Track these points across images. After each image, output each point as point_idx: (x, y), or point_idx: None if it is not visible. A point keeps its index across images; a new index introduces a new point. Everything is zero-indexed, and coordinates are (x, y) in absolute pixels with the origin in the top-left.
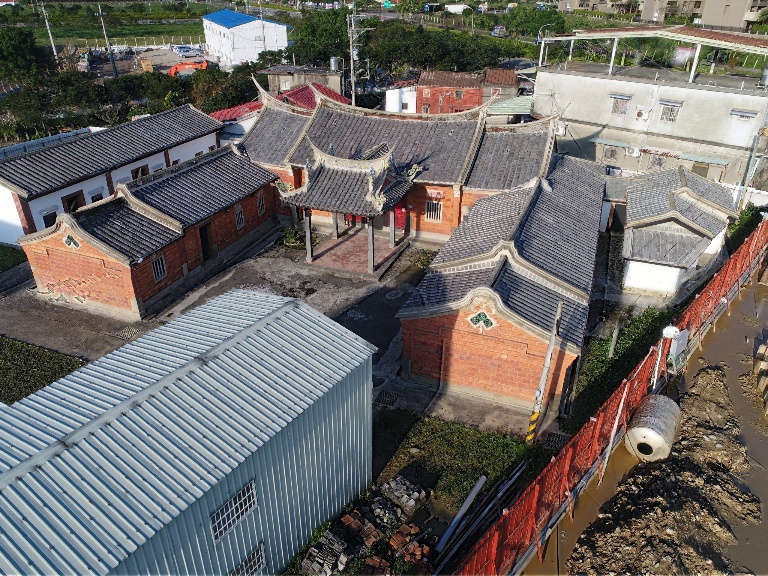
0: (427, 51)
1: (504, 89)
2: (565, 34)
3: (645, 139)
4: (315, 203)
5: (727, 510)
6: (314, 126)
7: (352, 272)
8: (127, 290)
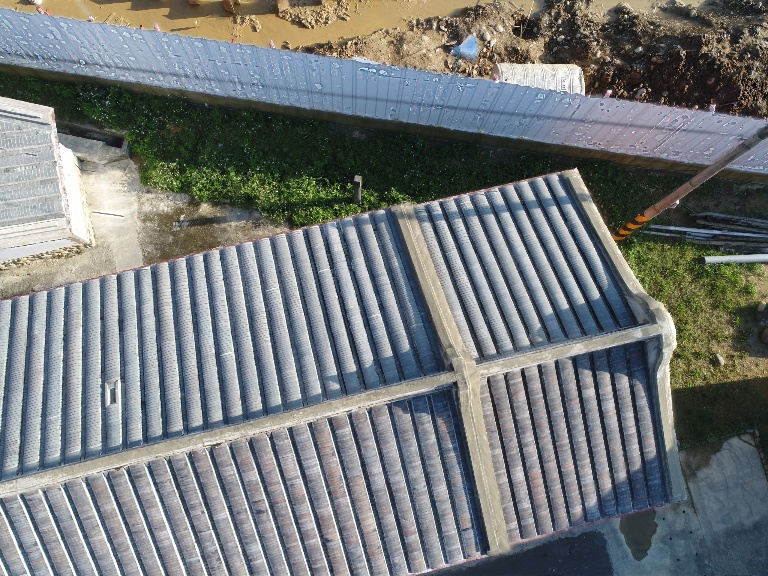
0: None
1: None
2: None
3: None
4: None
5: (591, 14)
6: None
7: None
8: None
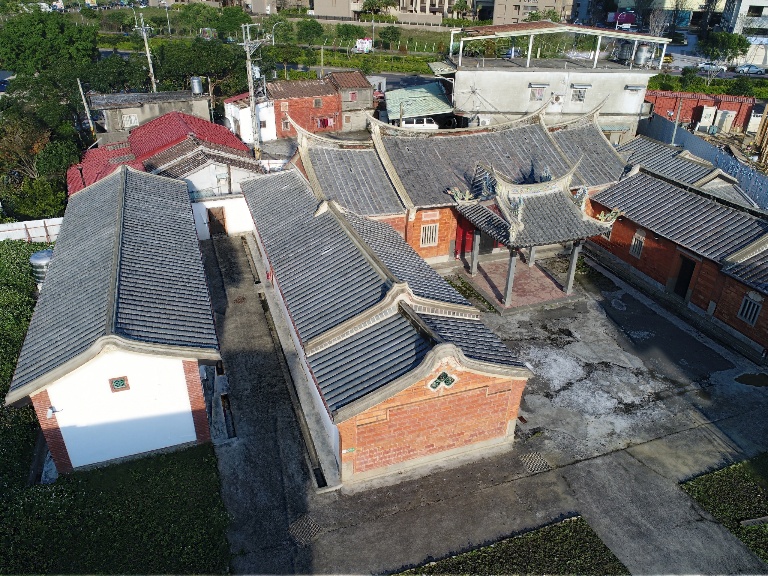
0: (223, 60)
1: (360, 92)
2: (482, 33)
3: (560, 119)
4: (544, 238)
5: None
6: (394, 159)
7: (557, 300)
8: (509, 411)
